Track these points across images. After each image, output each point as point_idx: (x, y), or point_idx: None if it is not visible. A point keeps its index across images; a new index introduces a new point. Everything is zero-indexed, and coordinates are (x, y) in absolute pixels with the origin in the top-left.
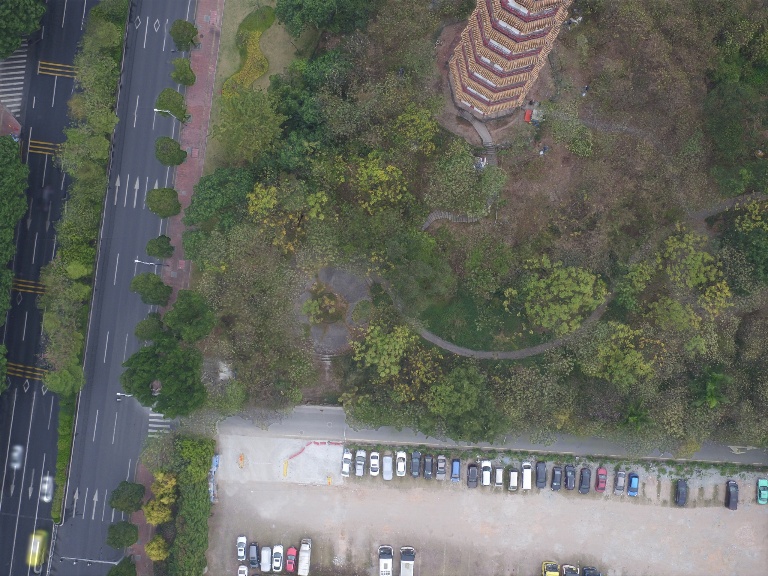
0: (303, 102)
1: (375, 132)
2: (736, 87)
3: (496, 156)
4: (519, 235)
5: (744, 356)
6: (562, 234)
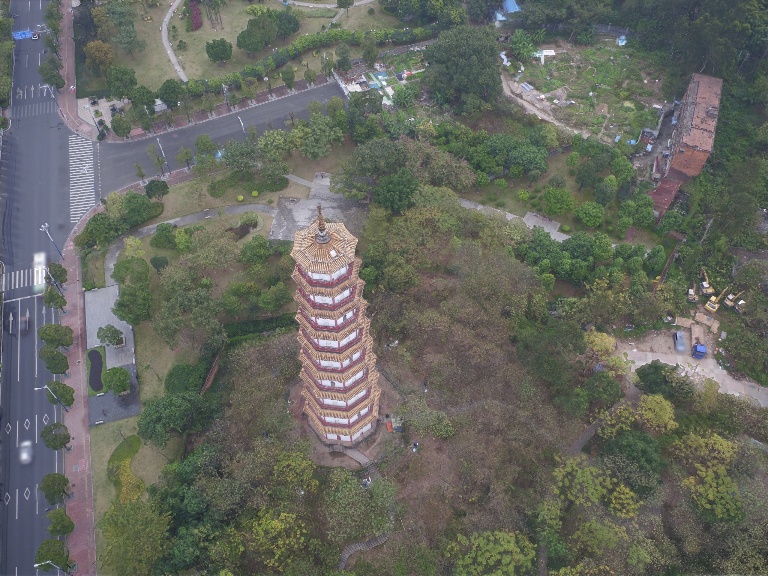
0: (184, 497)
1: (259, 493)
2: (534, 336)
3: (378, 472)
4: (431, 532)
5: (685, 547)
6: (466, 511)
